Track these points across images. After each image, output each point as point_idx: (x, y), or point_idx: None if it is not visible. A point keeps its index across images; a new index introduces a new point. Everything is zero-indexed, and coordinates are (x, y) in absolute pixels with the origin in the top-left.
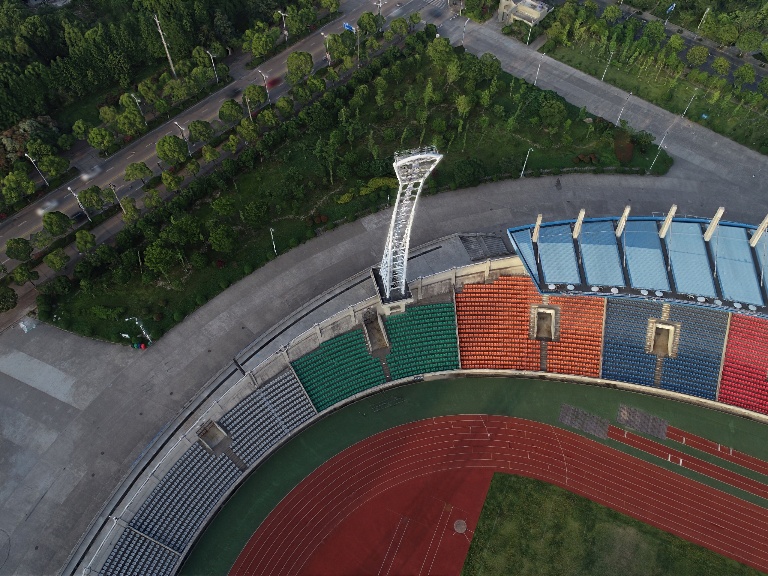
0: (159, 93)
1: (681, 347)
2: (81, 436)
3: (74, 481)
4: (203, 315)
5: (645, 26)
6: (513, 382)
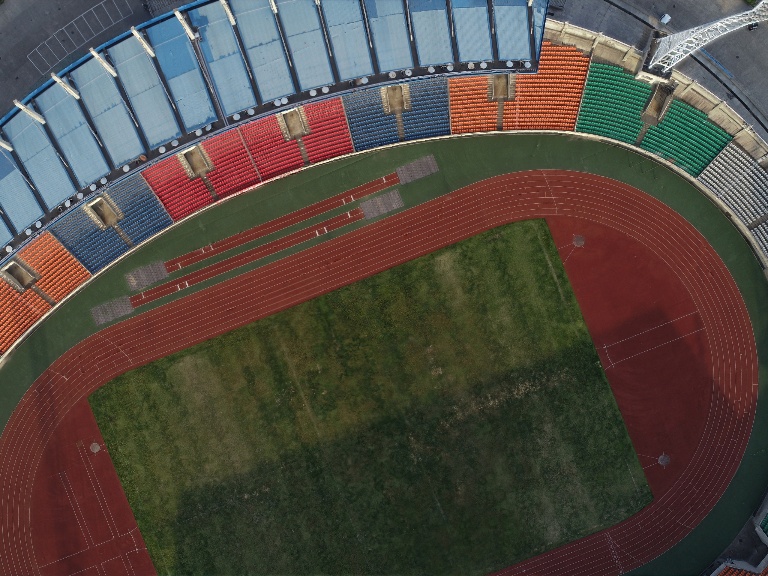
0: None
1: (120, 206)
2: None
3: None
4: None
5: None
6: (48, 324)
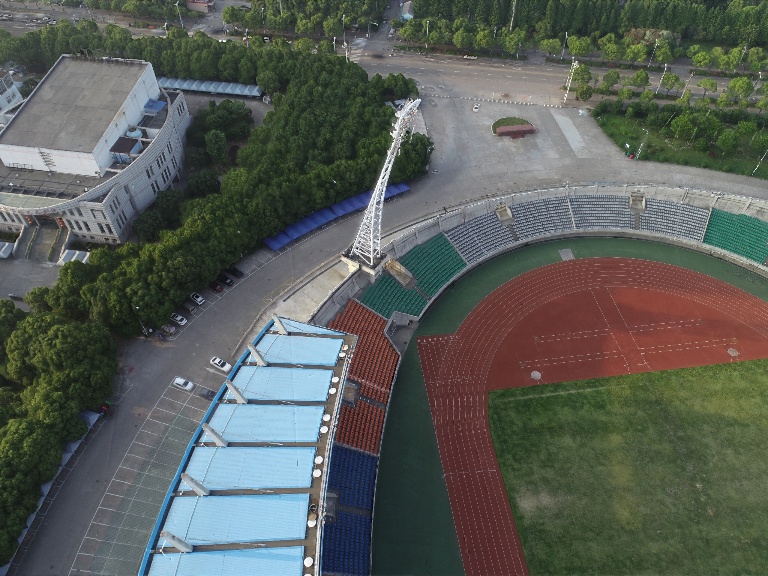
0: (761, 60)
1: None
2: (568, 165)
3: (550, 176)
4: (677, 168)
5: None
6: None
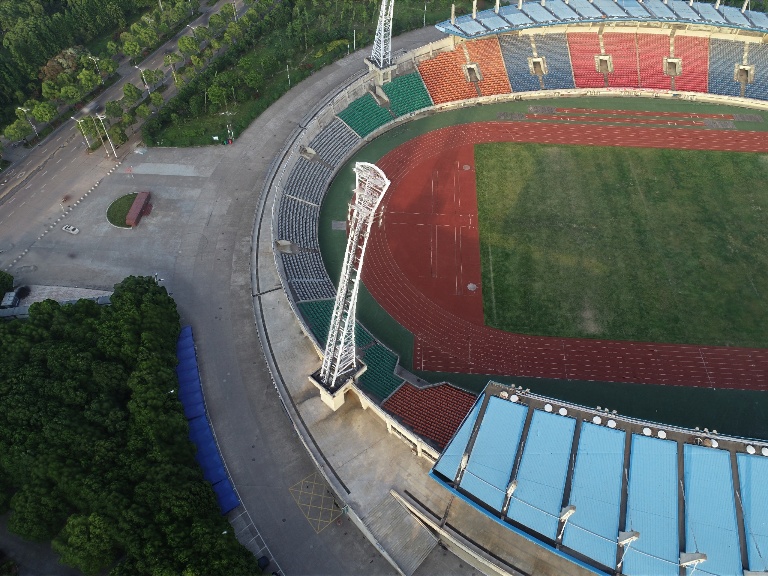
0: (157, 22)
1: (549, 68)
2: (217, 186)
3: (227, 204)
4: (260, 122)
5: None
6: (465, 110)
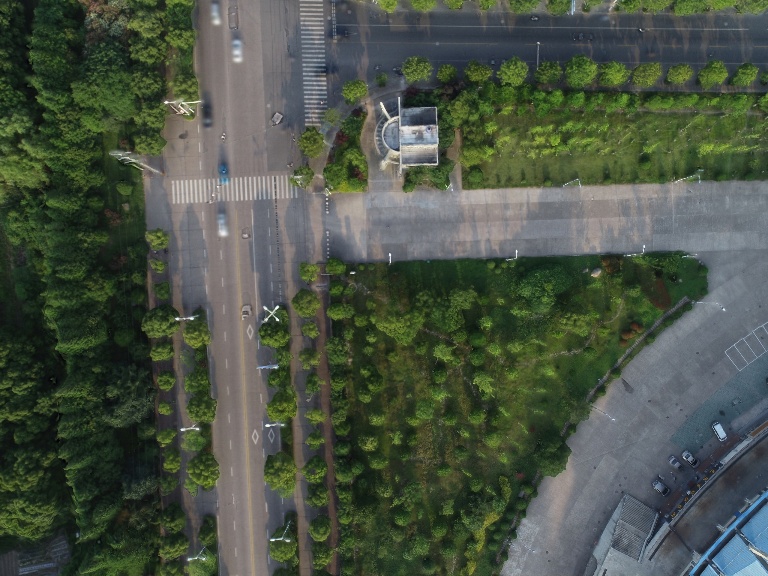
0: None
1: None
2: None
3: None
4: None
5: (569, 74)
6: None
